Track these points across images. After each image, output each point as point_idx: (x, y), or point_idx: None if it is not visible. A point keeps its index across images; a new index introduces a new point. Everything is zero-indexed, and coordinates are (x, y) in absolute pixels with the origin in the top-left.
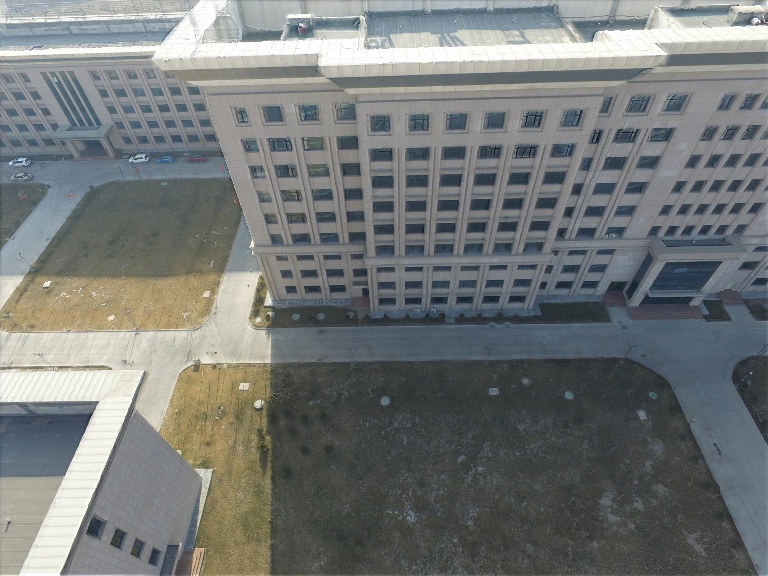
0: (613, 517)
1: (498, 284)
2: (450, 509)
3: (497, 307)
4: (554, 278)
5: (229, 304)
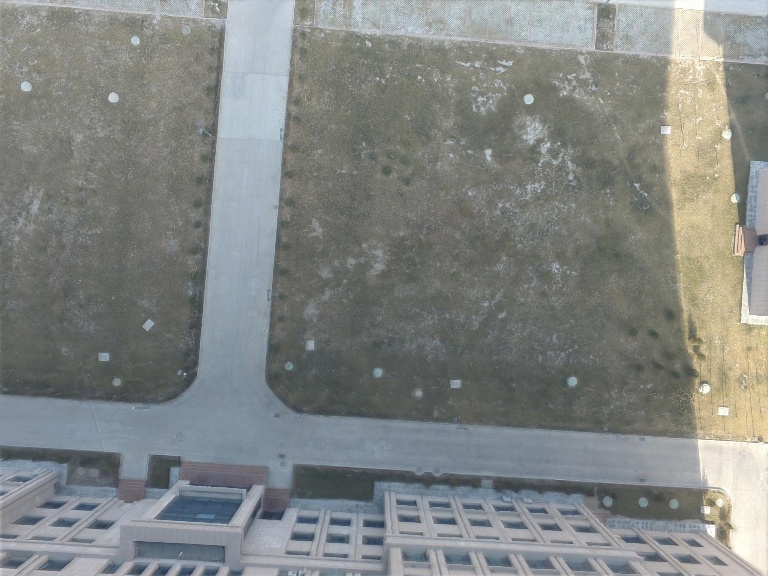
0: (378, 254)
1: (438, 521)
2: (520, 271)
3: (427, 498)
4: (356, 531)
5: (759, 532)
